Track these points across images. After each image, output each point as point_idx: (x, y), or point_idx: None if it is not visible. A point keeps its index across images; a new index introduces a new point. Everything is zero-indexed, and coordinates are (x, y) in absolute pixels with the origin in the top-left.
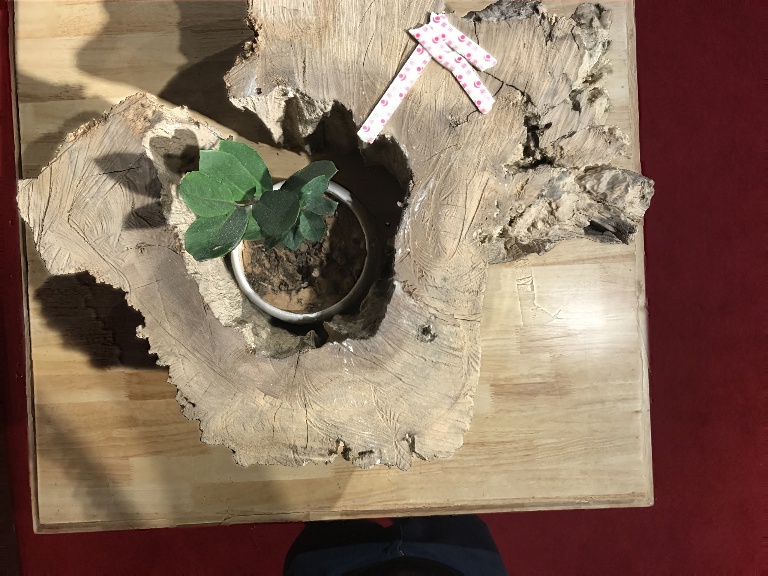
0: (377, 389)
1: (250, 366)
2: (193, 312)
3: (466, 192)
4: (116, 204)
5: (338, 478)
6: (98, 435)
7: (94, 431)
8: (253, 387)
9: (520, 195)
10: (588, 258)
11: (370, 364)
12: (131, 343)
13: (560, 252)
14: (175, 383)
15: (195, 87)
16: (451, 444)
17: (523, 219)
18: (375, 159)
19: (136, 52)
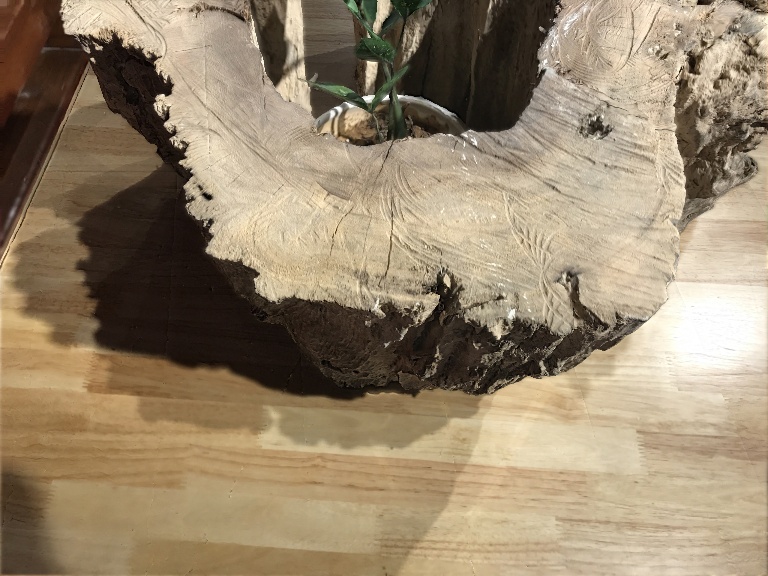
0: (514, 199)
1: (313, 150)
2: (245, 82)
3: (632, 17)
4: None
5: (385, 557)
6: (20, 438)
7: (17, 433)
8: (311, 180)
9: (707, 20)
10: (756, 279)
11: (503, 164)
12: (118, 317)
13: (716, 269)
14: (190, 165)
15: None
16: (646, 295)
17: (712, 53)
18: (486, 96)
19: None
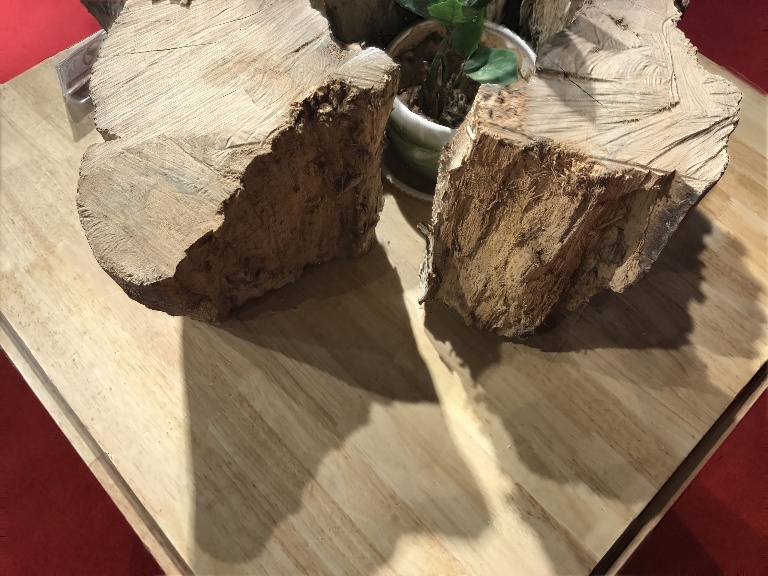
0: None
1: None
2: None
3: None
4: (612, 67)
5: None
6: None
7: None
8: None
9: None
10: None
11: None
12: (687, 234)
13: None
14: None
15: (394, 372)
16: None
17: None
18: None
19: (413, 471)
